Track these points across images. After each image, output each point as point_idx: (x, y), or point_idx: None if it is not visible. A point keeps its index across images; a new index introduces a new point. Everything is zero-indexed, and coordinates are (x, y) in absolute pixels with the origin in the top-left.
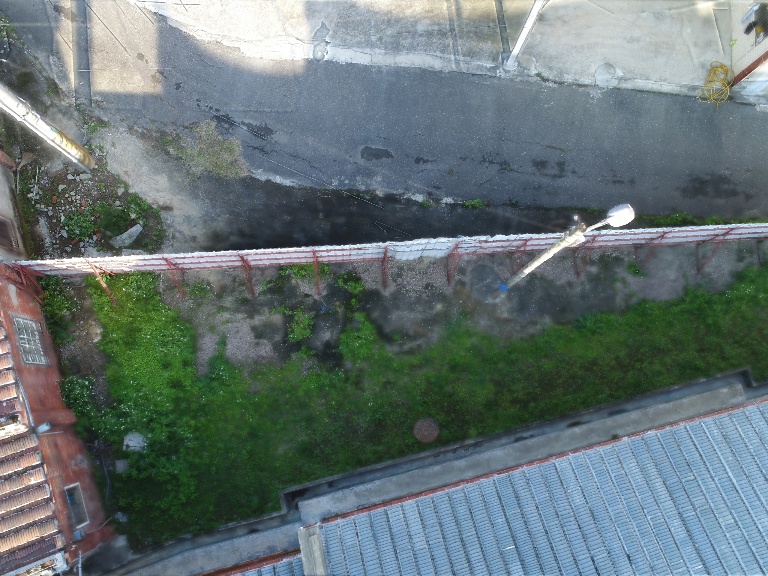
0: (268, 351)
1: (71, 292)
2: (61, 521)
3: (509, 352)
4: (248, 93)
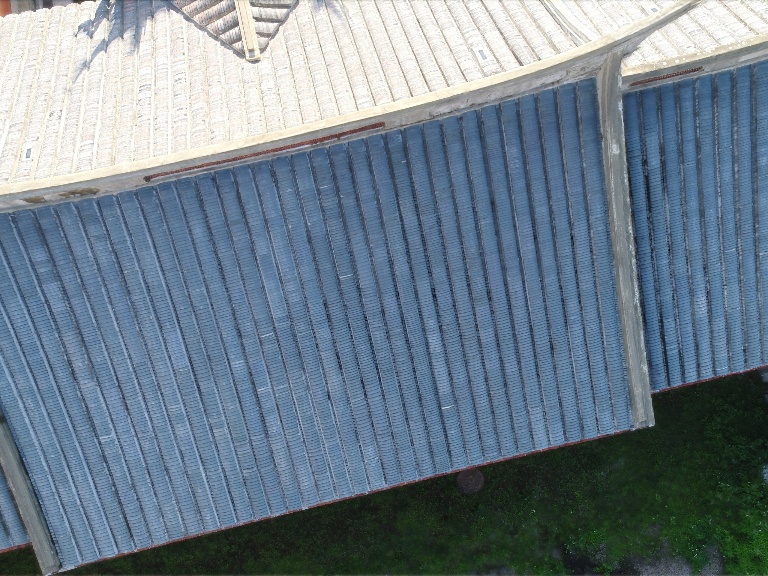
0: (645, 571)
1: None
2: None
3: (379, 567)
4: None
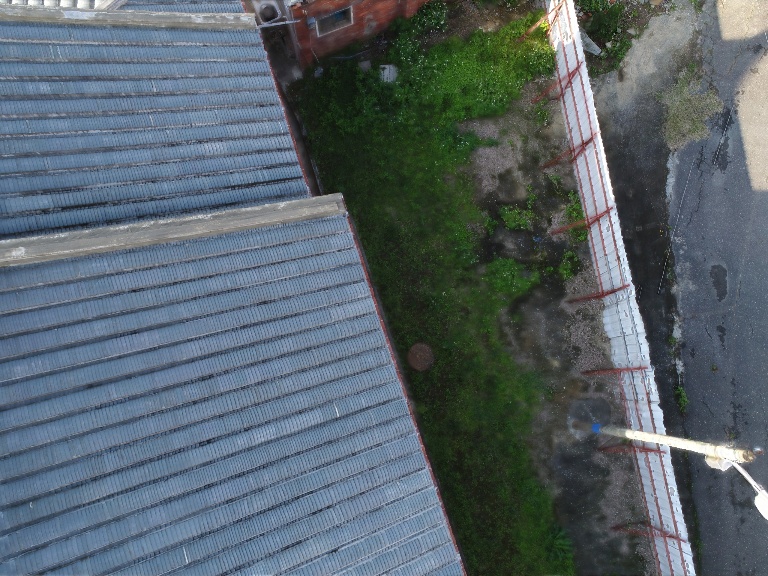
0: (487, 188)
1: (525, 1)
2: (325, 2)
3: (515, 446)
4: (762, 140)
